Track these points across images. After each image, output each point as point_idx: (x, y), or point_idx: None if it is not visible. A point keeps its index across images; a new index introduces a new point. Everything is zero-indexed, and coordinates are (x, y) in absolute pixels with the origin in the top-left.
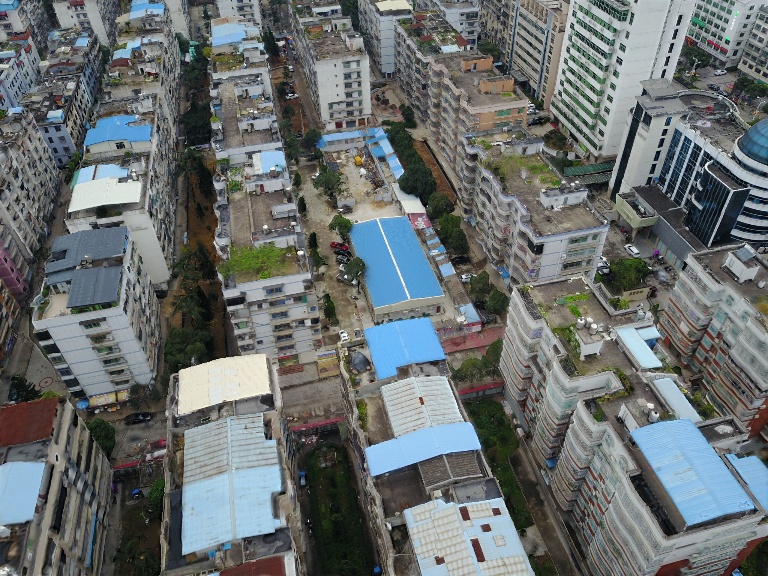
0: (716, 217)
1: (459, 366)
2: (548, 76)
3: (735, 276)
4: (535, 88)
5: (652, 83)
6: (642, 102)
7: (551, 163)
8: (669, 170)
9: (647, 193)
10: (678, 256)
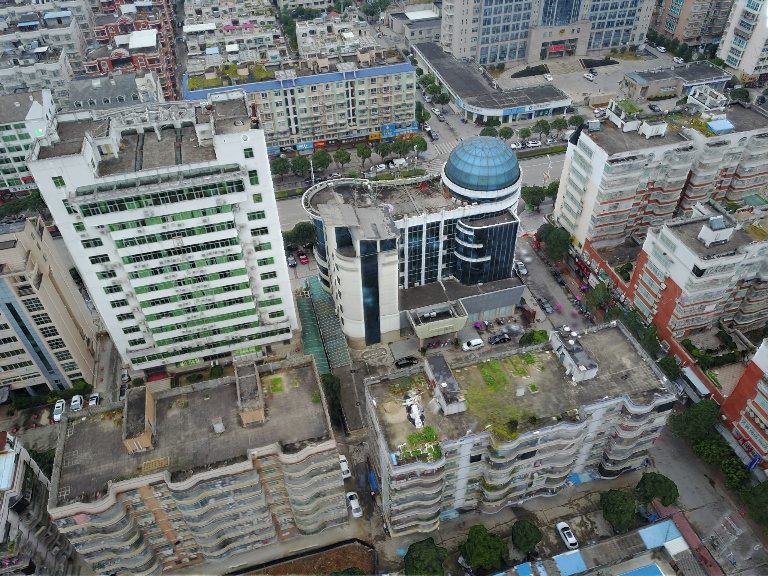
0: (511, 251)
1: (741, 560)
2: (67, 348)
3: (721, 242)
4: (40, 382)
5: (331, 217)
6: (365, 237)
7: (327, 386)
8: (404, 267)
9: (409, 302)
10: (501, 306)
